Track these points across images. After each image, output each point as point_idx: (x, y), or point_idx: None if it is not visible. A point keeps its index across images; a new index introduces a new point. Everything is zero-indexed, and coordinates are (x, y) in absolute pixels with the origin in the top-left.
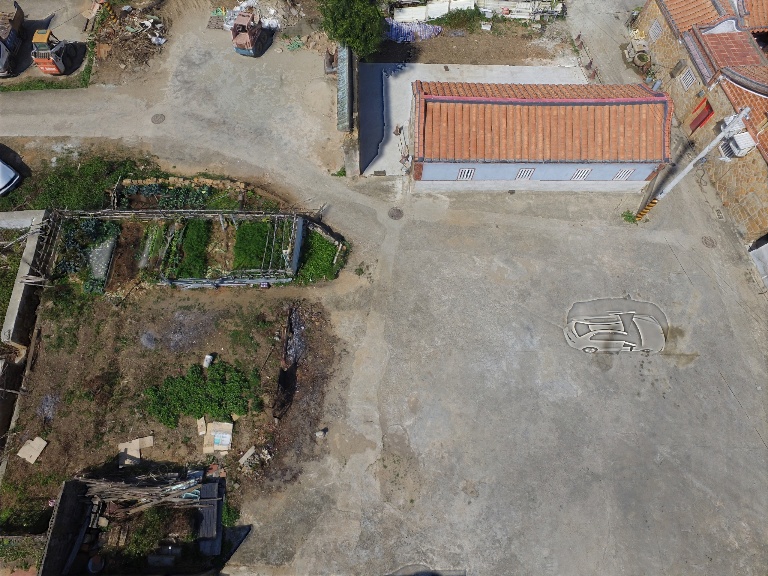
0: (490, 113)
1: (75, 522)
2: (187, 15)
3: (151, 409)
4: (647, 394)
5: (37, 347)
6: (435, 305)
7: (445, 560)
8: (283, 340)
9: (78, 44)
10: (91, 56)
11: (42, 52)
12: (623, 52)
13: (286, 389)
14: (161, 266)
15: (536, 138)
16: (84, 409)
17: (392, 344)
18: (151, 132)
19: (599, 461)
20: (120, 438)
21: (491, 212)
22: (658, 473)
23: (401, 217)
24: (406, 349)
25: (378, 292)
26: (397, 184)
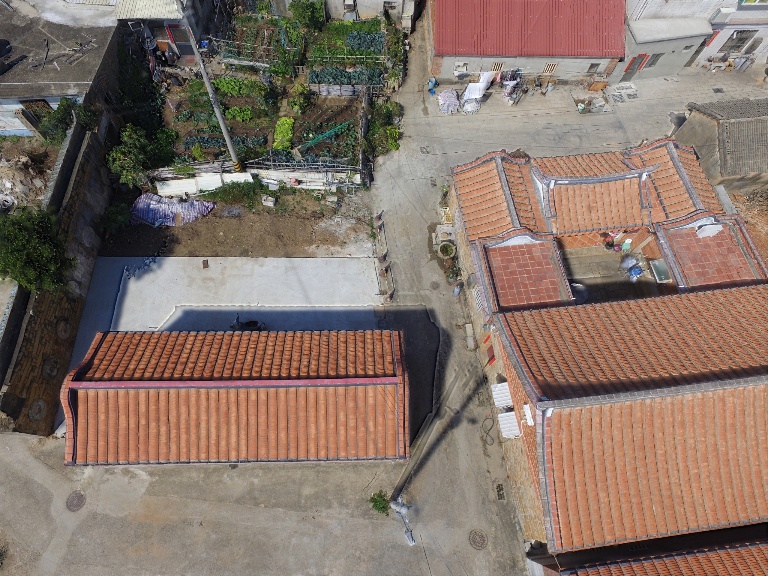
0: (165, 399)
1: None
2: None
3: None
4: None
5: None
6: None
7: None
8: None
9: None
10: None
11: None
12: (430, 235)
13: None
14: None
15: (229, 430)
16: None
17: None
18: None
19: None
20: None
21: (199, 499)
22: None
23: (81, 507)
24: None
25: None
26: None
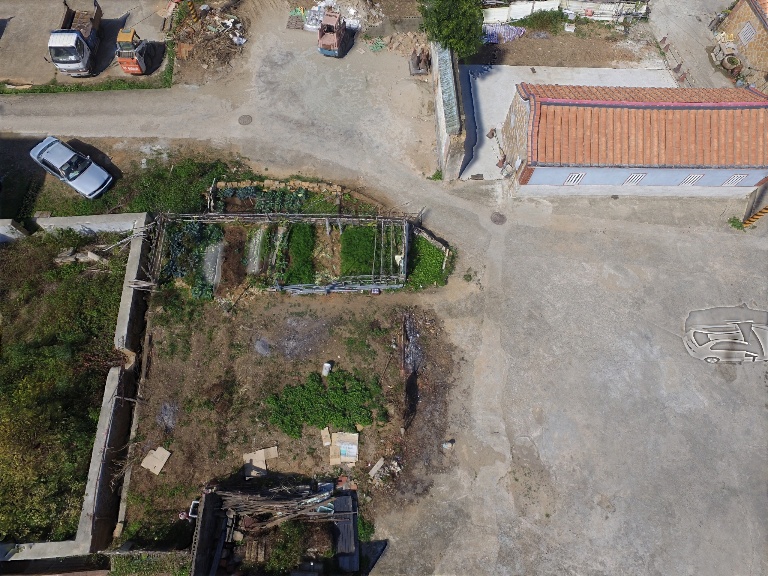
0: (605, 117)
1: (211, 536)
2: (265, 15)
3: (274, 419)
4: None
5: (150, 354)
6: (549, 313)
7: None
8: (400, 348)
9: (157, 43)
10: (171, 56)
11: (126, 51)
12: (710, 55)
13: (409, 399)
14: (268, 271)
15: (651, 142)
16: (204, 418)
17: (510, 353)
18: (239, 133)
19: (734, 475)
20: (244, 448)
21: (596, 217)
22: None
23: (504, 222)
24: (525, 358)
25: (490, 299)
26: (497, 188)
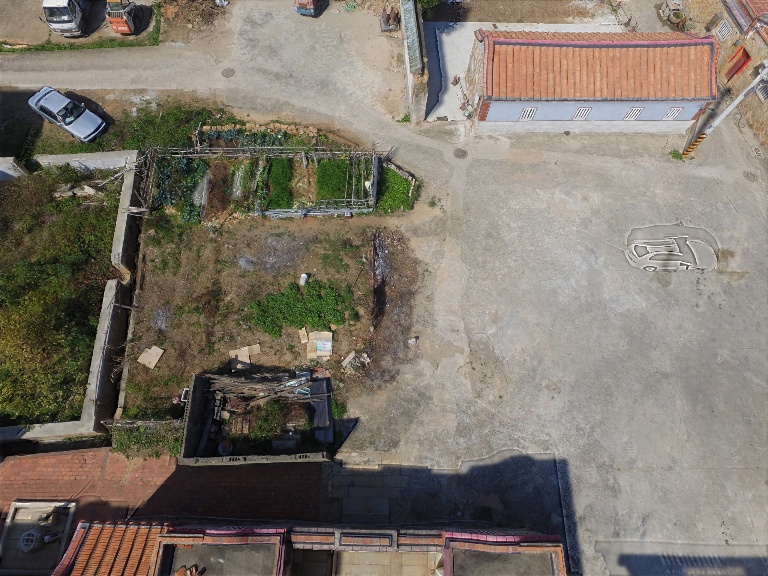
0: (552, 55)
1: (201, 414)
2: None
3: (256, 321)
4: (705, 305)
5: (143, 270)
6: (505, 232)
7: (535, 445)
8: (370, 262)
9: (144, 7)
10: (158, 17)
11: (115, 12)
12: (658, 11)
13: (378, 303)
14: (250, 199)
15: (594, 78)
16: (194, 322)
17: (470, 265)
18: (223, 85)
19: (666, 362)
20: (230, 346)
21: (549, 151)
22: (720, 371)
23: (466, 156)
24: (483, 269)
25: (452, 221)
26: (460, 128)
